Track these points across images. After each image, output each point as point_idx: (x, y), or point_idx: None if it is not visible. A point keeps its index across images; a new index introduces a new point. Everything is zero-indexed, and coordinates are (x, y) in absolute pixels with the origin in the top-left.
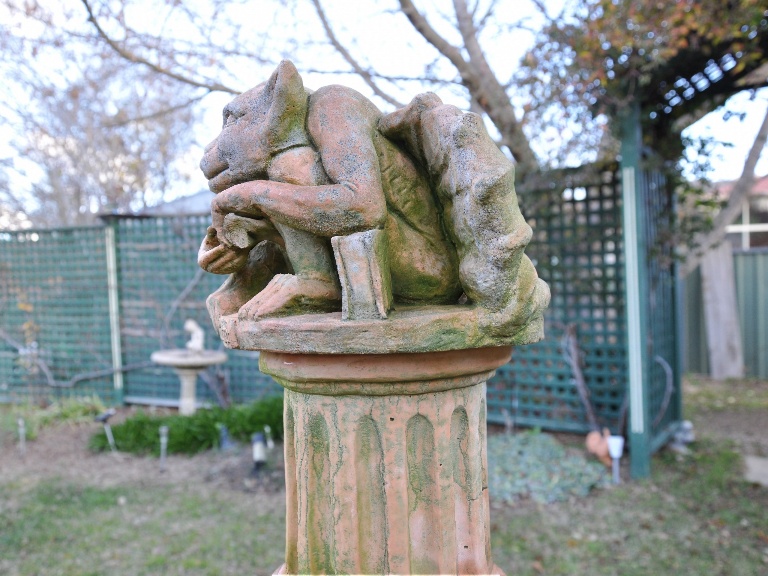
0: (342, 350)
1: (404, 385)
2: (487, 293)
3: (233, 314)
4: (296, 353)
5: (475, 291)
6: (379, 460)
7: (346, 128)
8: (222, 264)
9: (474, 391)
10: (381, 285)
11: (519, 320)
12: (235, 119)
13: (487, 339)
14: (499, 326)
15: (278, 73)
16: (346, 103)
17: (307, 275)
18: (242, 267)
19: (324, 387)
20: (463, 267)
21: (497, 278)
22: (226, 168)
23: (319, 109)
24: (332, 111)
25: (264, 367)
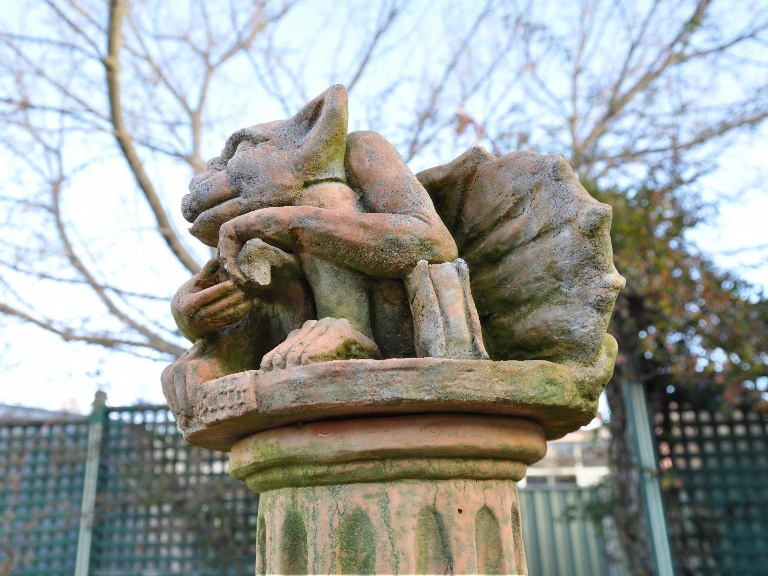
0: (440, 395)
1: (477, 462)
2: (584, 341)
3: None
4: None
5: (563, 342)
6: (443, 572)
7: (399, 166)
8: (222, 308)
9: None
10: None
11: (607, 378)
12: (253, 144)
13: (579, 398)
14: (593, 382)
15: (333, 94)
16: (392, 146)
17: None
18: (214, 333)
19: (374, 467)
20: (544, 317)
21: (597, 322)
22: (235, 196)
23: (365, 145)
24: (381, 149)
25: (270, 451)
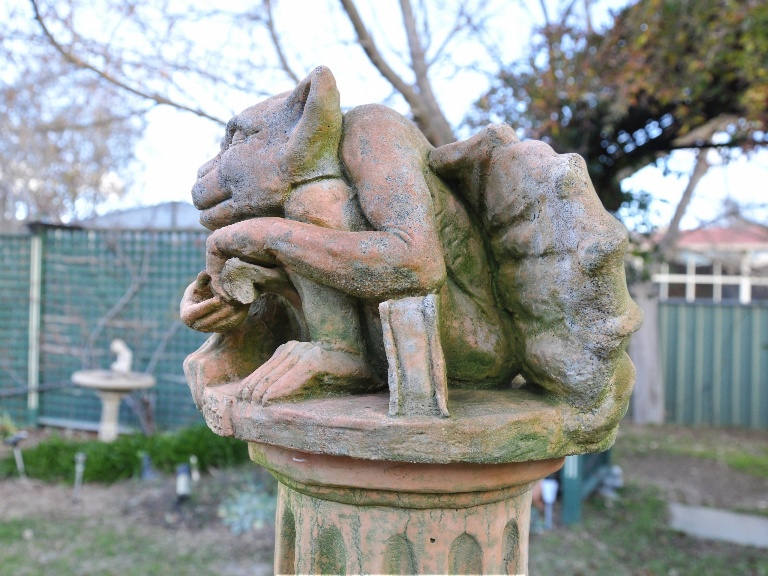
0: (386, 456)
1: (452, 497)
2: (580, 388)
3: (224, 387)
4: (317, 453)
5: (560, 383)
6: None
7: (395, 160)
8: (214, 321)
9: (525, 498)
10: (443, 371)
11: (613, 423)
12: (244, 136)
13: (571, 446)
14: (590, 431)
15: (313, 82)
16: (394, 128)
17: (329, 344)
18: None
19: (345, 494)
20: (543, 350)
21: (596, 371)
22: (228, 198)
23: (359, 133)
24: (377, 137)
25: (261, 459)
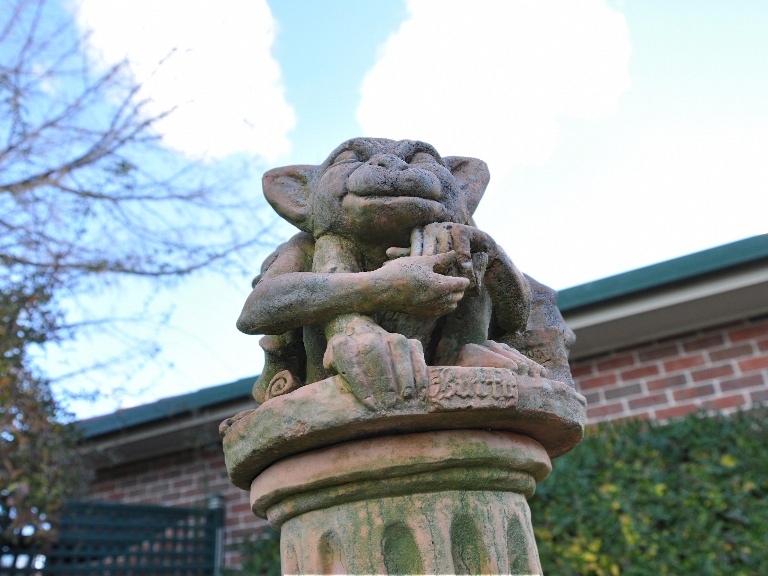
0: None
1: None
2: None
3: None
4: (558, 425)
5: None
6: None
7: None
8: (457, 300)
9: None
10: None
11: None
12: None
13: None
14: None
15: None
16: None
17: None
18: None
19: None
20: None
21: None
22: None
23: None
24: None
25: (477, 449)
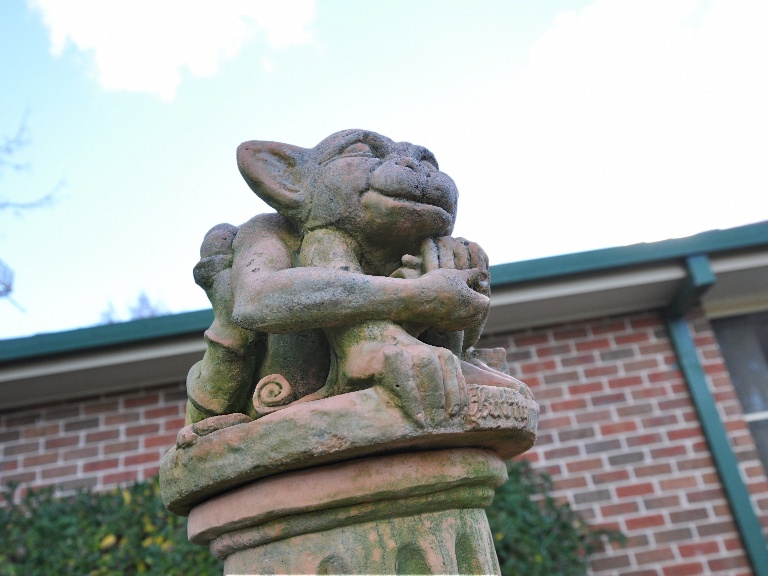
0: None
1: None
2: None
3: None
4: None
5: None
6: None
7: None
8: None
9: None
10: None
11: None
12: None
13: None
14: None
15: None
16: None
17: None
18: None
19: None
20: None
21: None
22: None
23: None
24: None
25: (484, 468)
